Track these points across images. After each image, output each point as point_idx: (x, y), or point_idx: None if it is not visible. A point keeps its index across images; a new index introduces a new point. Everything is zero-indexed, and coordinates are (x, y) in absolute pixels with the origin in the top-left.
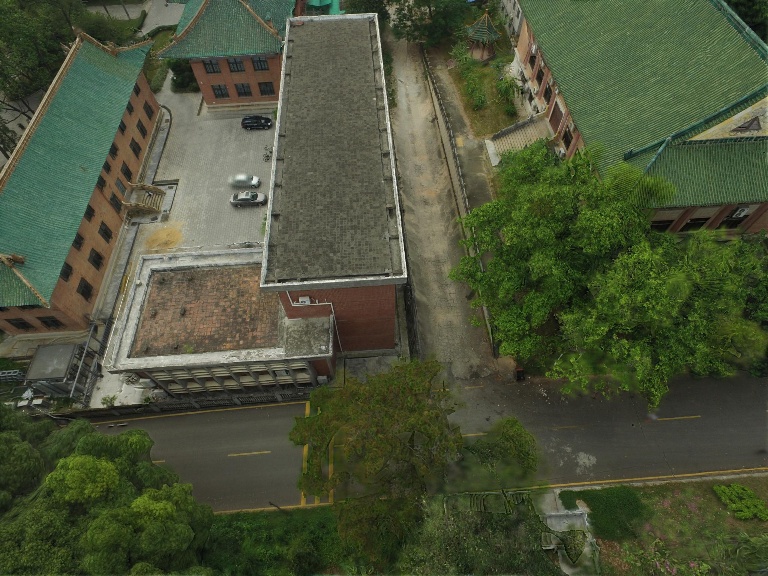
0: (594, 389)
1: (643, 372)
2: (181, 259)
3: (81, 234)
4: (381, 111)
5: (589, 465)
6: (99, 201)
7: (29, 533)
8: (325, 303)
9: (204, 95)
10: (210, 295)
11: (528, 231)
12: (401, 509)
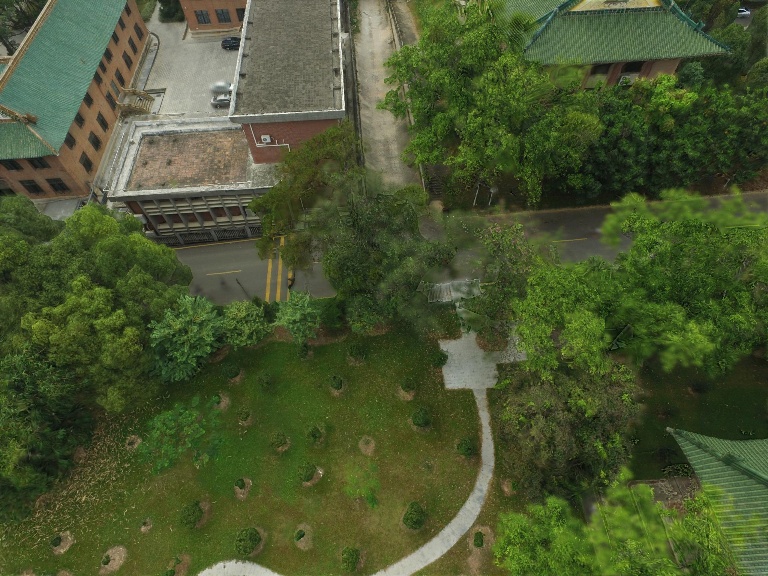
0: (505, 223)
1: (514, 158)
2: (167, 126)
3: (82, 116)
4: (334, 6)
5: (495, 272)
6: (97, 94)
7: (55, 246)
8: (283, 144)
9: (188, 21)
10: (191, 151)
11: (429, 54)
12: (325, 229)
